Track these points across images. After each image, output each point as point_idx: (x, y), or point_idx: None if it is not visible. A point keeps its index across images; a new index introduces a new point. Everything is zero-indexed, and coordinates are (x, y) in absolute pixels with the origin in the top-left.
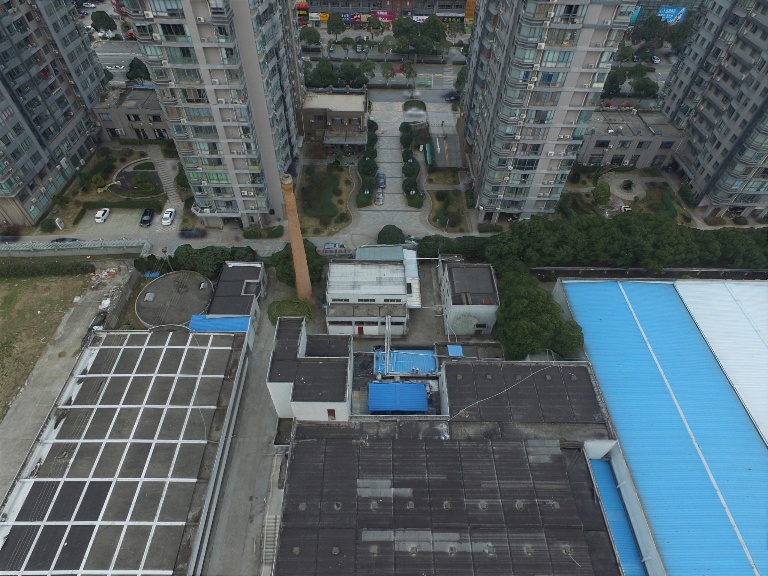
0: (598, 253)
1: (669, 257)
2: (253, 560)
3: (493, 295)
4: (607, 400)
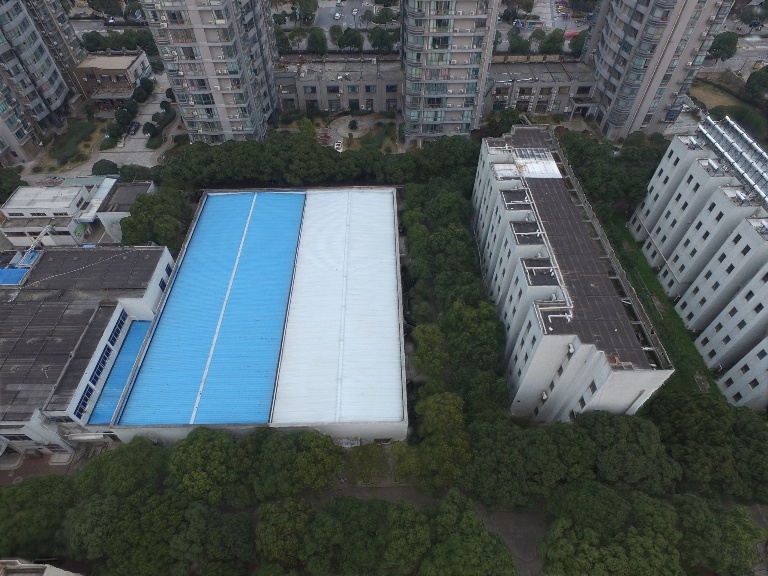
0: (238, 169)
1: (300, 170)
2: None
3: None
4: (180, 277)
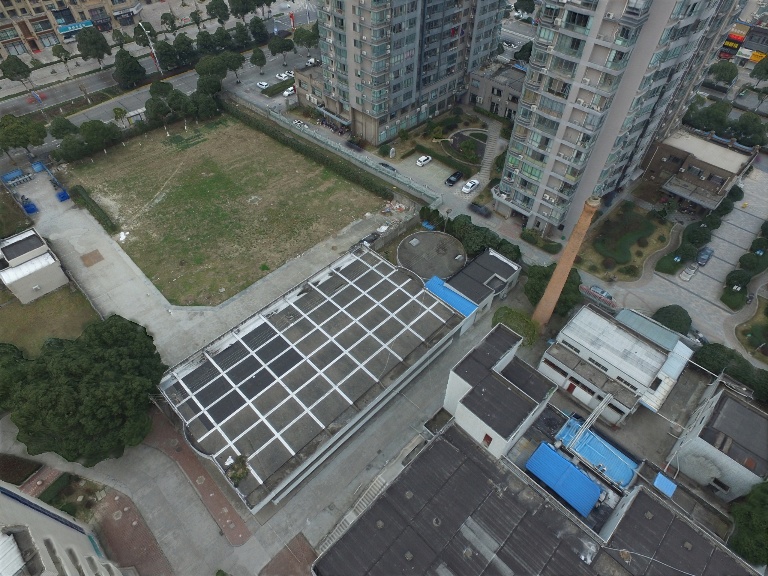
0: None
1: None
2: (349, 499)
3: (766, 464)
4: None
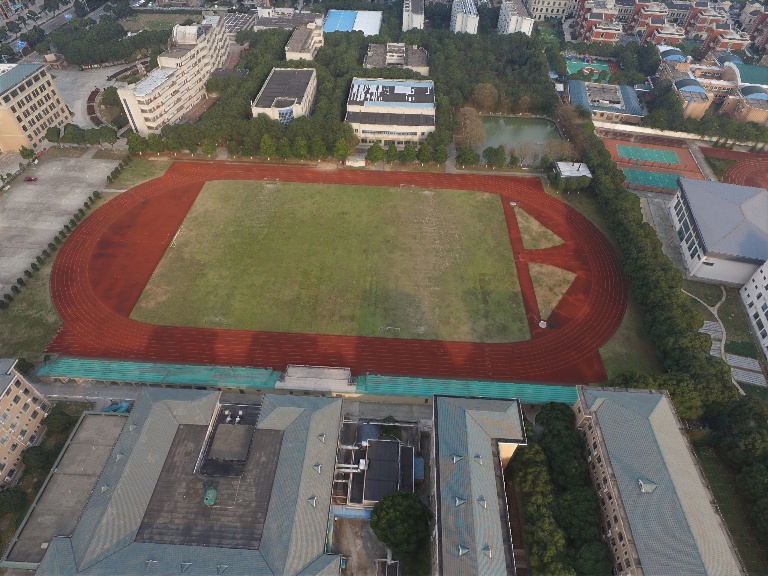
0: (339, 4)
1: (356, 5)
2: None
3: None
4: None
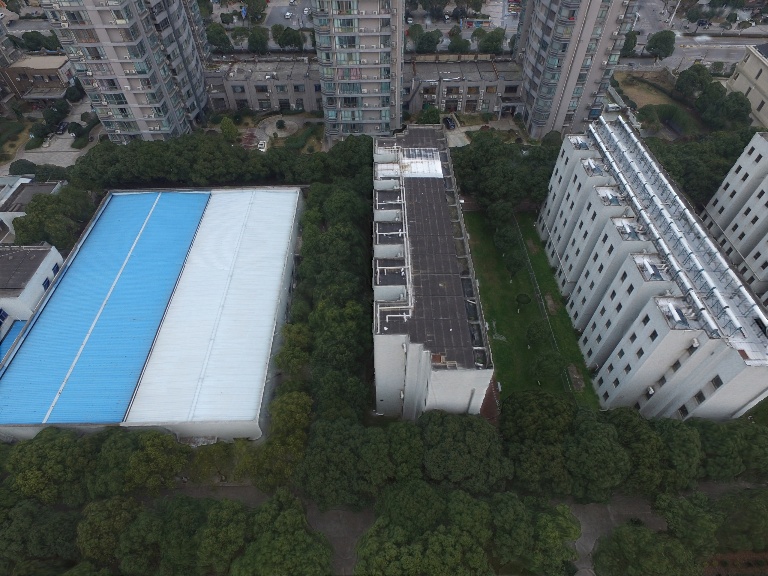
0: (143, 169)
1: (204, 170)
2: None
3: None
4: (67, 277)
